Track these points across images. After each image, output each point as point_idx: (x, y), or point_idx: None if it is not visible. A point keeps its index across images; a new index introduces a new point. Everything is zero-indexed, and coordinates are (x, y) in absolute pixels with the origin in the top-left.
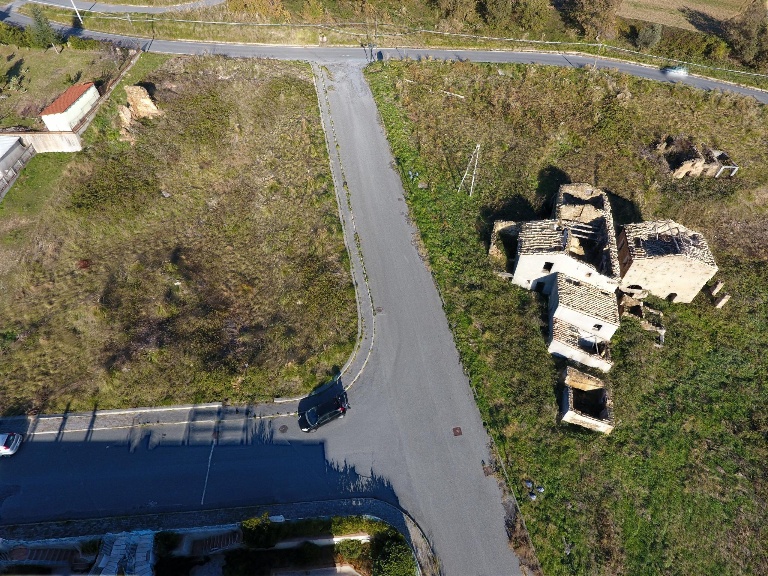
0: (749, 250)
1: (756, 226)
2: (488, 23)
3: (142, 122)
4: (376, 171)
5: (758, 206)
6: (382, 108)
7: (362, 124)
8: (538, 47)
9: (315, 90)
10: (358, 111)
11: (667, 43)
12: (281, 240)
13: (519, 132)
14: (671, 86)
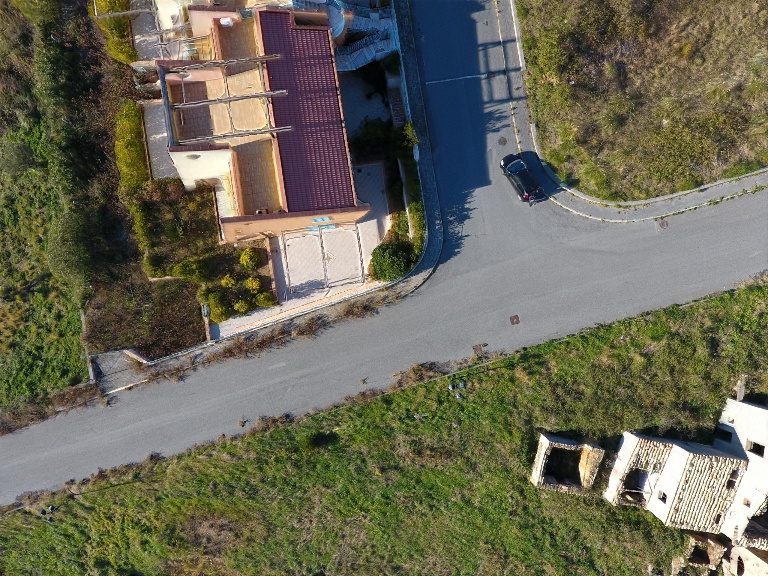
0: None
1: None
2: None
3: None
4: None
5: None
6: None
7: None
8: None
9: None
10: None
11: None
12: None
13: None
14: None
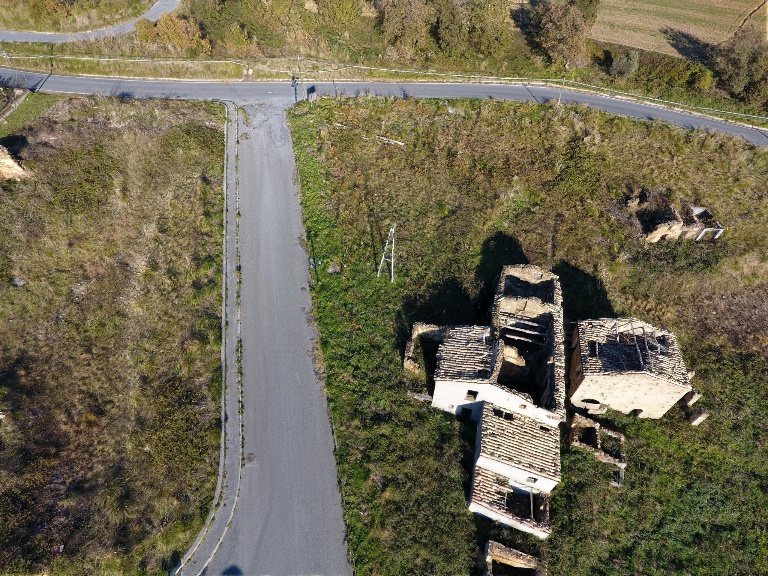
0: (735, 336)
1: (744, 302)
2: (442, 49)
3: (4, 186)
4: (280, 249)
5: (746, 276)
6: (300, 162)
7: (273, 184)
8: None
9: (224, 140)
10: (272, 166)
11: (646, 71)
12: (146, 349)
13: (464, 189)
14: (648, 124)
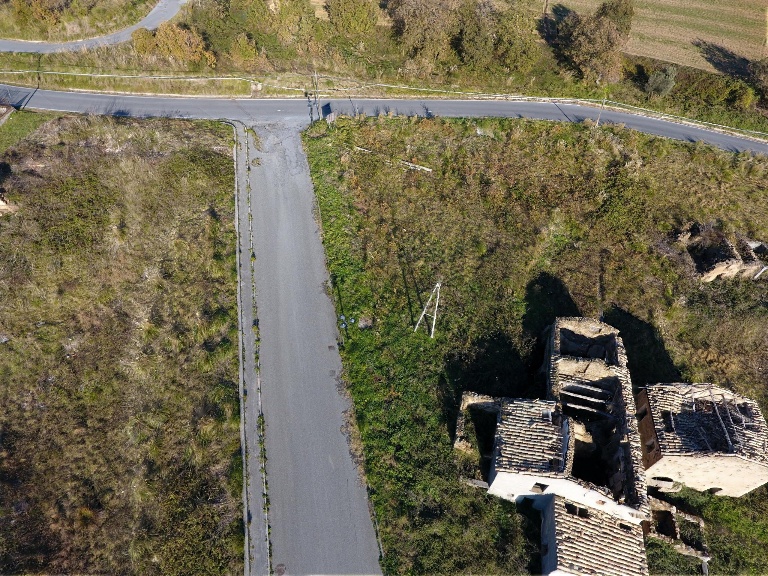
0: None
1: None
2: (465, 63)
3: None
4: (302, 298)
5: None
6: (320, 193)
7: (291, 219)
8: (526, 94)
9: (233, 167)
10: (288, 198)
11: (681, 87)
12: (150, 426)
13: (501, 223)
14: (690, 147)
